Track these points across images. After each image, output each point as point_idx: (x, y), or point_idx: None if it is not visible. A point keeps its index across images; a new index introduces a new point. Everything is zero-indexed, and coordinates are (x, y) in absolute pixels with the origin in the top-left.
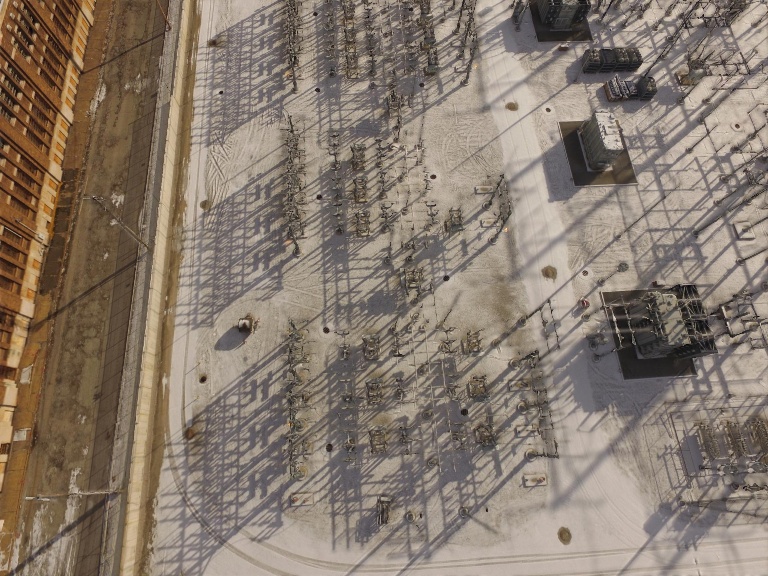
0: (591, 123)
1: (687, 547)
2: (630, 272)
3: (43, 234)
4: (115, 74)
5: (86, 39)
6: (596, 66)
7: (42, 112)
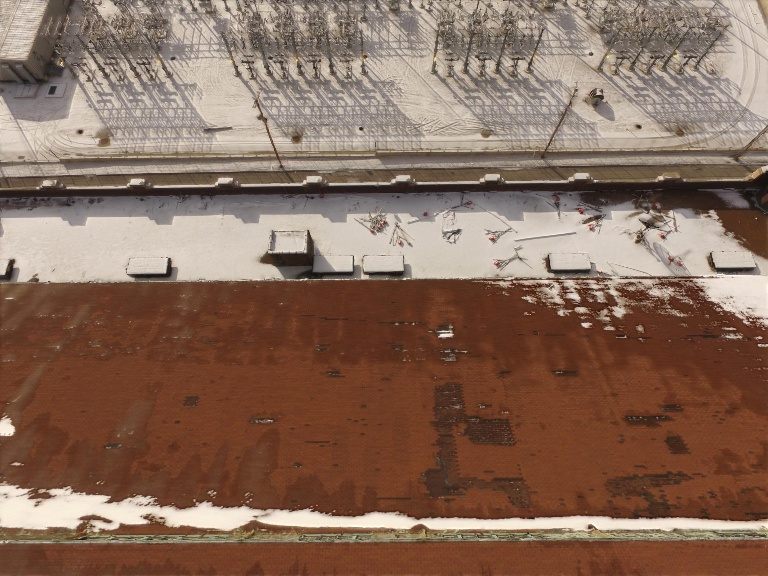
0: None
1: None
2: None
3: None
4: None
5: None
6: None
7: None
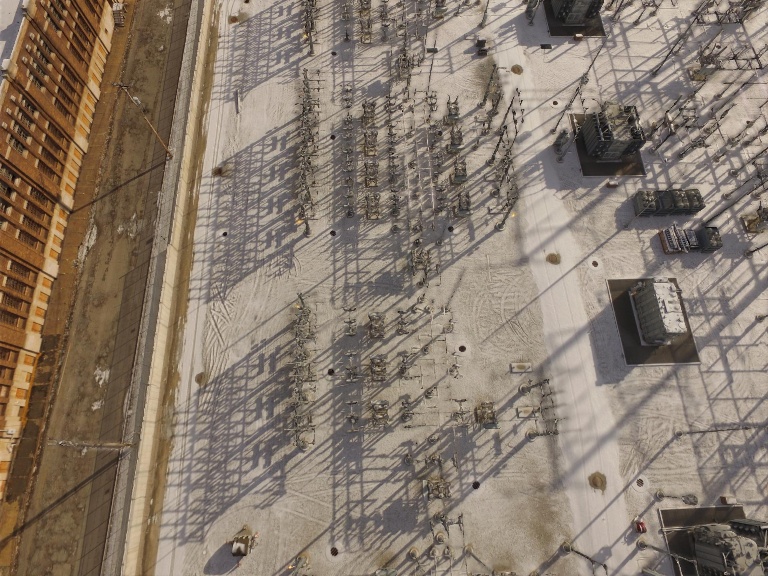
0: (647, 292)
1: None
2: (693, 482)
3: (13, 427)
4: (108, 213)
5: (78, 170)
6: (651, 211)
7: (19, 281)
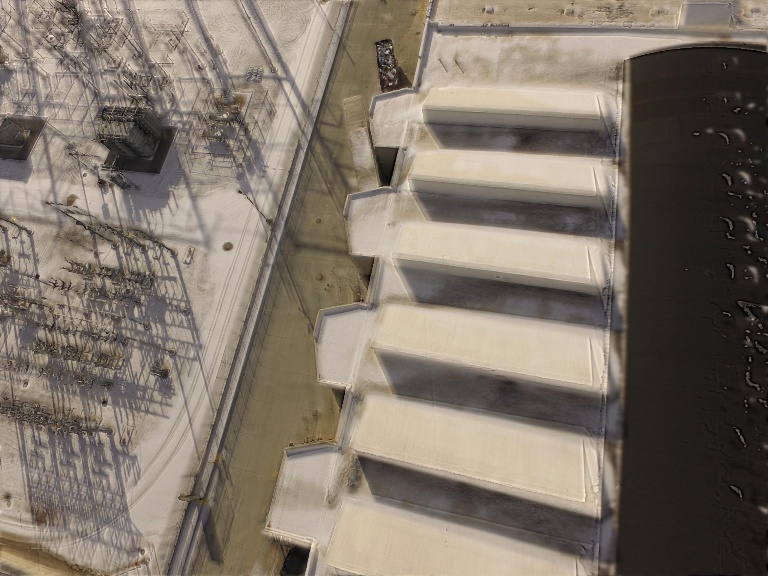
0: None
1: (265, 171)
2: (100, 145)
3: None
4: None
5: None
6: None
7: None
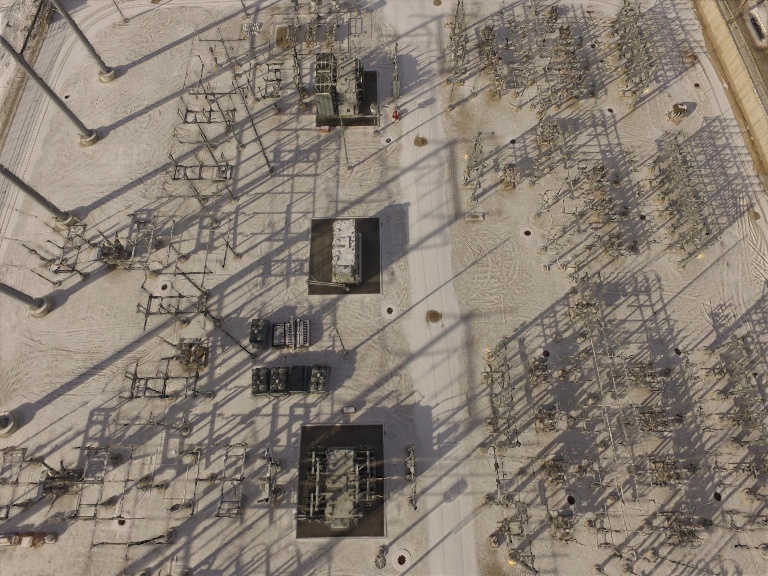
0: None
1: None
2: (347, 141)
3: None
4: None
5: None
6: None
7: None
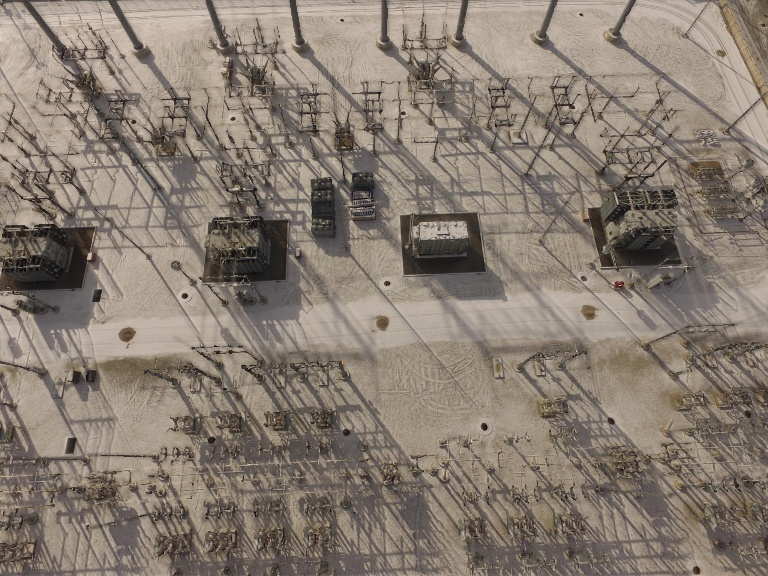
0: (426, 245)
1: None
2: (575, 239)
3: None
4: None
5: None
6: None
7: None
